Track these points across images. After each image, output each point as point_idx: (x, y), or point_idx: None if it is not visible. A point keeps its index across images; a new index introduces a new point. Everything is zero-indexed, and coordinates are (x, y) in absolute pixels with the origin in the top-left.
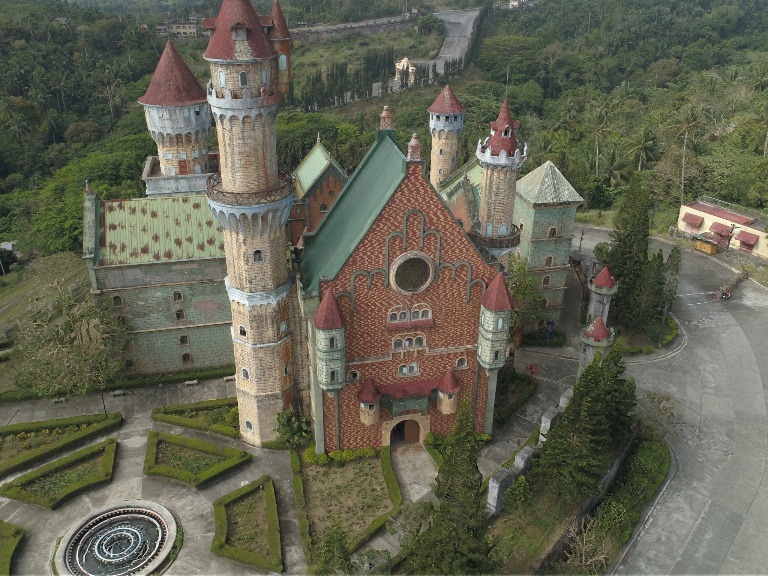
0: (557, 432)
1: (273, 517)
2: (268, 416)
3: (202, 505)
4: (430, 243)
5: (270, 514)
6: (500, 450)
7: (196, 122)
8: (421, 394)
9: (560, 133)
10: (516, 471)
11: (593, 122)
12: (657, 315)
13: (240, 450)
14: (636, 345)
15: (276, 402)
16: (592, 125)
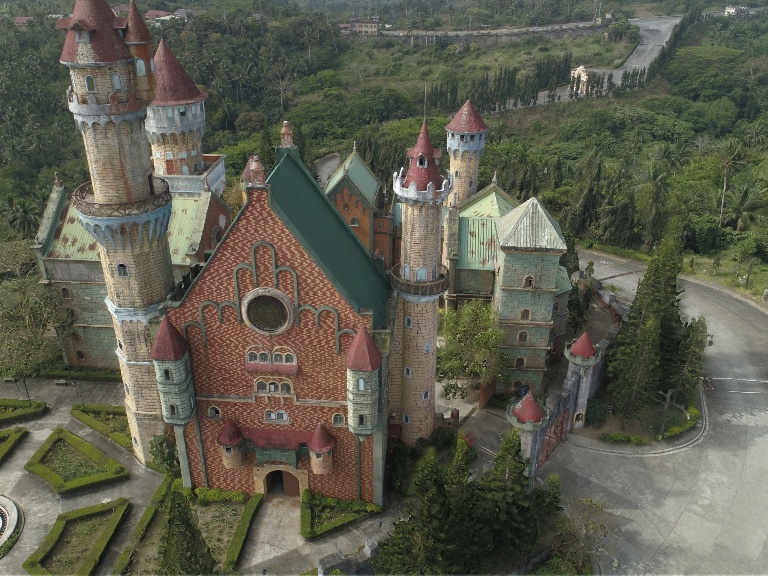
0: (406, 526)
1: (100, 545)
2: (150, 436)
3: (54, 515)
4: (286, 281)
5: (100, 541)
6: (384, 526)
7: (181, 123)
8: (286, 446)
9: (682, 162)
10: (360, 559)
11: (722, 152)
12: (659, 400)
13: (118, 465)
14: (629, 431)
15: (156, 423)
16: (721, 156)
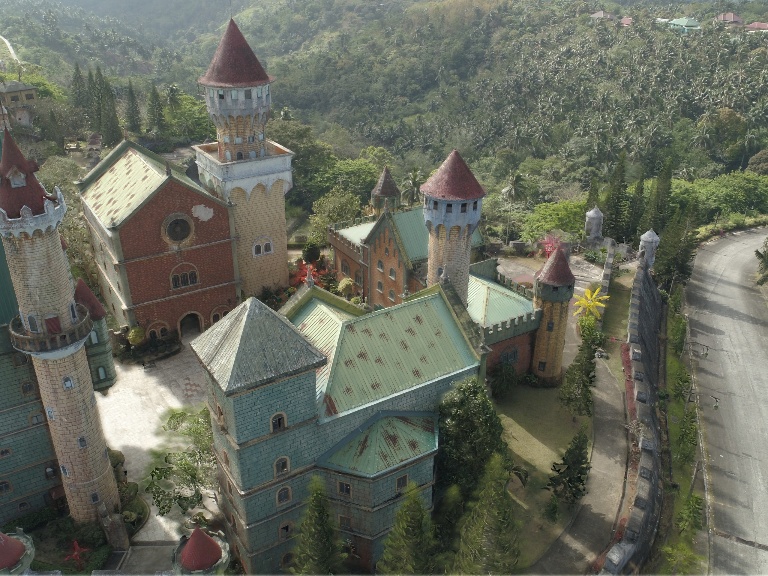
0: None
1: None
2: None
3: None
4: None
5: None
6: None
7: (220, 105)
8: None
9: None
10: None
11: None
12: None
13: None
14: None
15: None
16: None
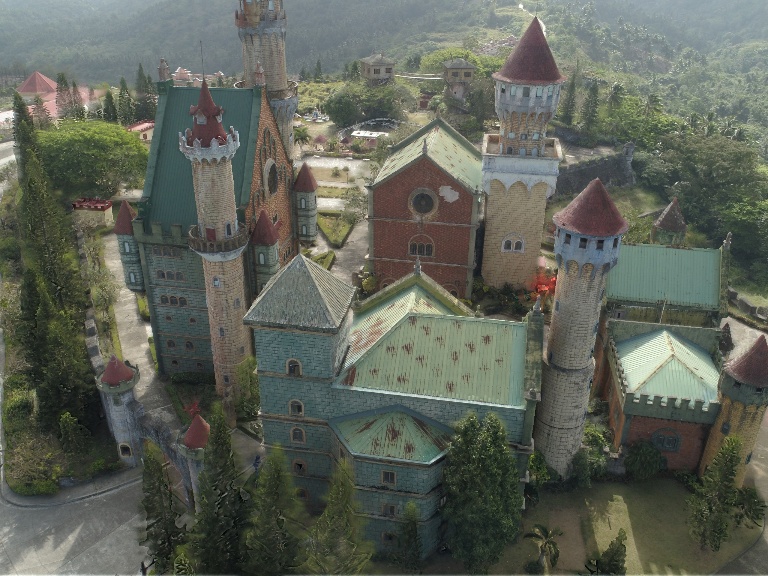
0: None
1: None
2: None
3: None
4: None
5: None
6: (144, 378)
7: None
8: None
9: None
10: None
11: None
12: (159, 574)
13: None
14: None
15: None
16: None
